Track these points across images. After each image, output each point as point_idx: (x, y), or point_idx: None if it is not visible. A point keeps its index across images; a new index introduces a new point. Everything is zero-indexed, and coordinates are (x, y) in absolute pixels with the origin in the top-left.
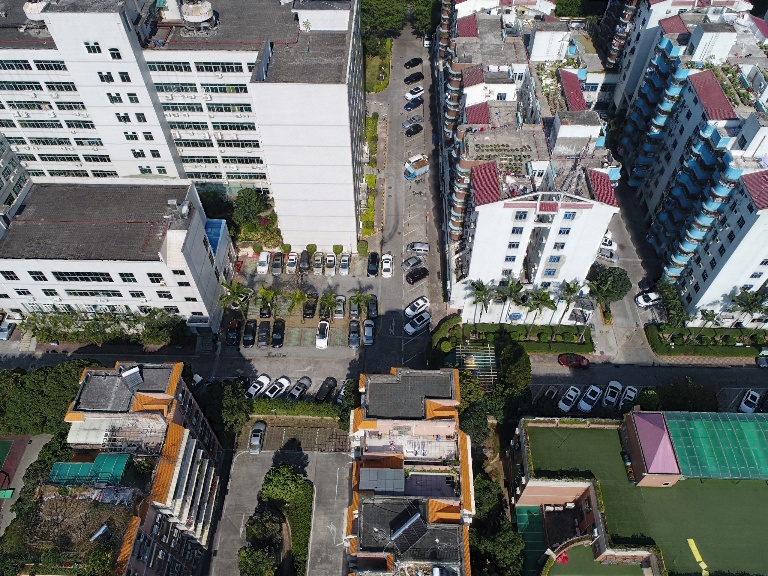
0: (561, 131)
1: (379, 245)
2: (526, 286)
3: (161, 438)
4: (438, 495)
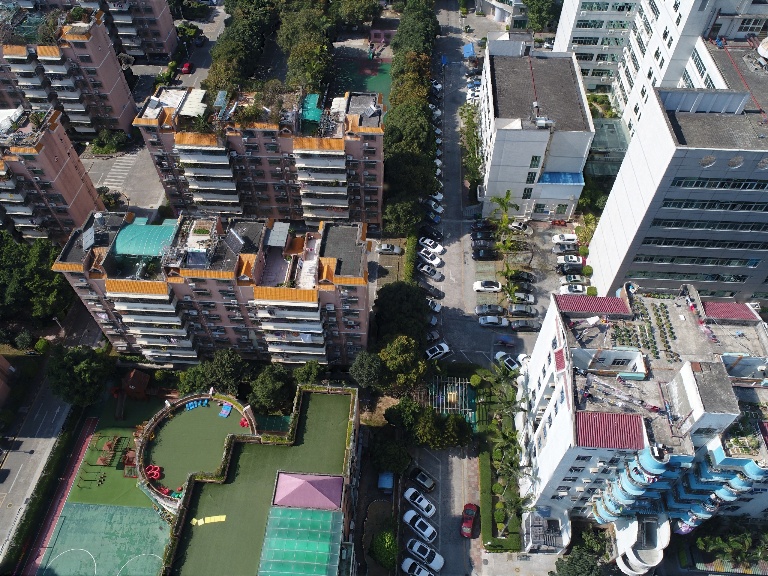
0: (685, 367)
1: None
2: (532, 432)
3: None
4: (271, 279)
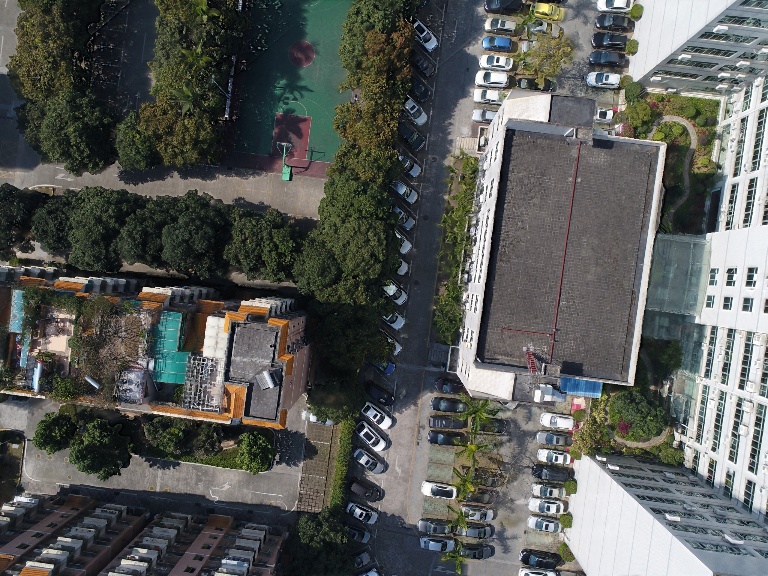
0: None
1: (577, 569)
2: None
3: (218, 400)
4: None
